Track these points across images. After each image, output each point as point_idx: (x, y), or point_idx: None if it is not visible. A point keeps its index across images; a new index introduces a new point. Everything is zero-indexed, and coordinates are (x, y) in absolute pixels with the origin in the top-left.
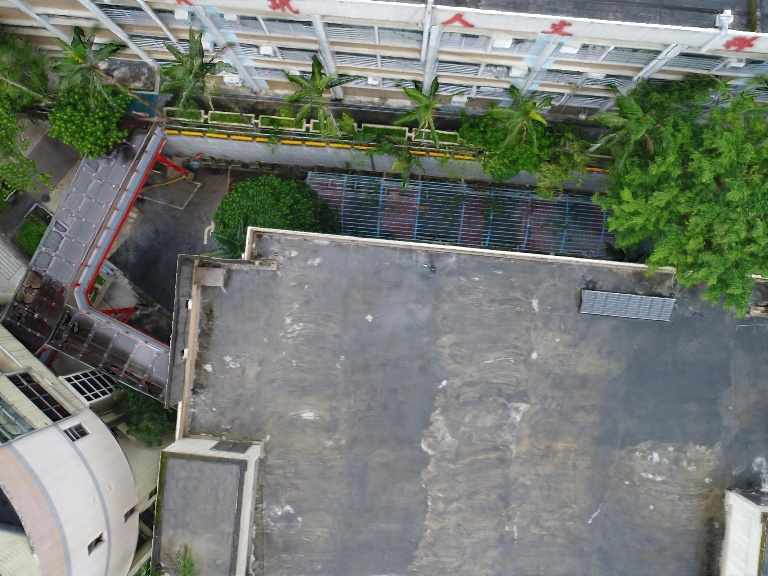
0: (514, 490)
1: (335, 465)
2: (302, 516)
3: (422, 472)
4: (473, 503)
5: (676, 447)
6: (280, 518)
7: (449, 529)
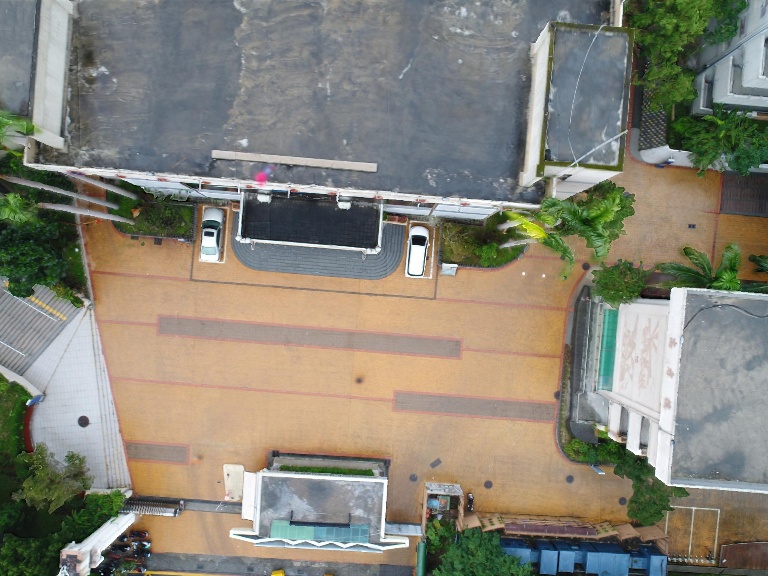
0: (326, 47)
1: (149, 25)
2: (117, 77)
3: (235, 30)
4: (286, 60)
5: (483, 2)
6: (95, 80)
7: (263, 87)
